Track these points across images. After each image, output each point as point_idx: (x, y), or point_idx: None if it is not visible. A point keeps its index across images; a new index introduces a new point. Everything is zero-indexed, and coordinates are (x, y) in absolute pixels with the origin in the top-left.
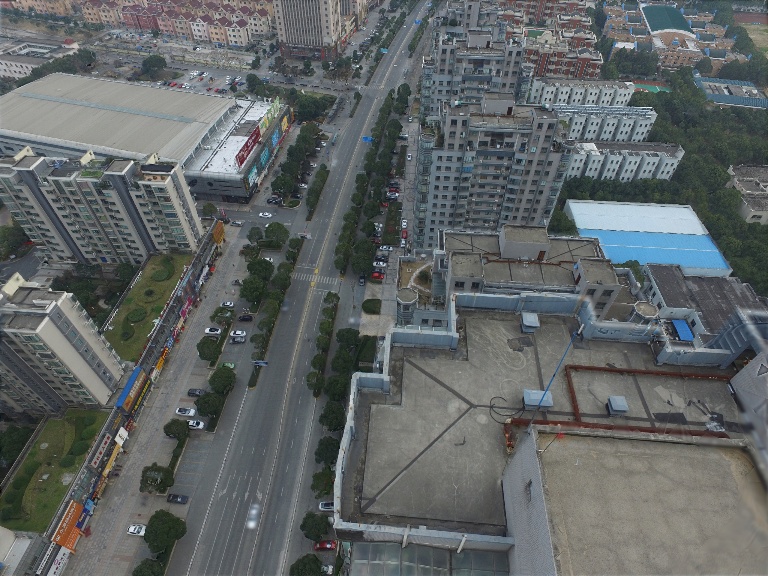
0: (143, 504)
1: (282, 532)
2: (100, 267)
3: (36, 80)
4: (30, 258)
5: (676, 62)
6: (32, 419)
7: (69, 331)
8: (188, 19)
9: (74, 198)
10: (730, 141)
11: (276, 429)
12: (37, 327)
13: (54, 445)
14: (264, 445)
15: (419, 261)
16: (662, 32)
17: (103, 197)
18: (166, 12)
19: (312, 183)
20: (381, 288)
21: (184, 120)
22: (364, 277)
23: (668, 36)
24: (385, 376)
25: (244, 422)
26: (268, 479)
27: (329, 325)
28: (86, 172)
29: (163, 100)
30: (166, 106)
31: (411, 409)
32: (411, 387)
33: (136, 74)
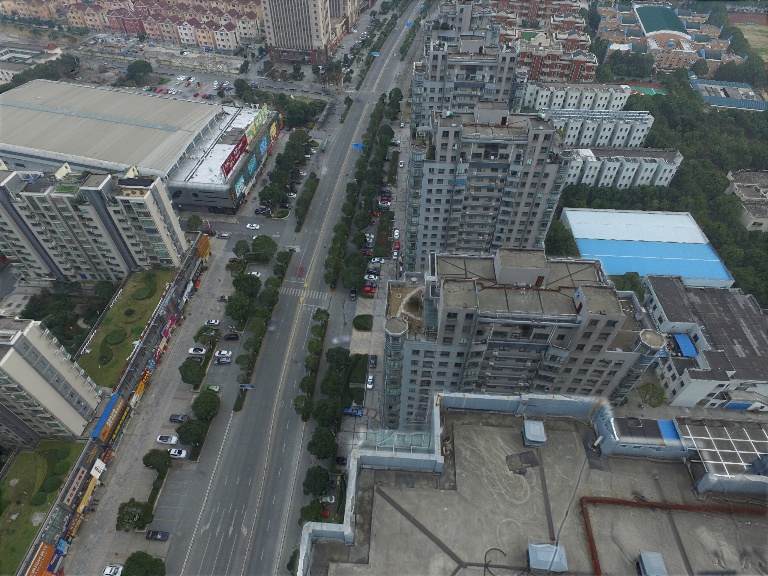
0: (121, 542)
1: (268, 570)
2: (79, 284)
3: (16, 87)
4: (6, 275)
5: (671, 64)
6: (4, 450)
7: (37, 361)
8: (175, 23)
9: (49, 214)
10: (728, 145)
11: (262, 457)
12: (0, 360)
13: (24, 481)
14: (250, 475)
15: (409, 285)
16: (657, 33)
17: (80, 213)
18: (152, 16)
19: (301, 192)
20: (373, 303)
21: (168, 128)
22: (355, 291)
23: (663, 37)
24: (346, 528)
25: (229, 450)
26: (254, 512)
27: (318, 344)
28: (61, 187)
29: (147, 107)
30: (150, 114)
31: (381, 570)
32: (382, 534)
33: (121, 80)
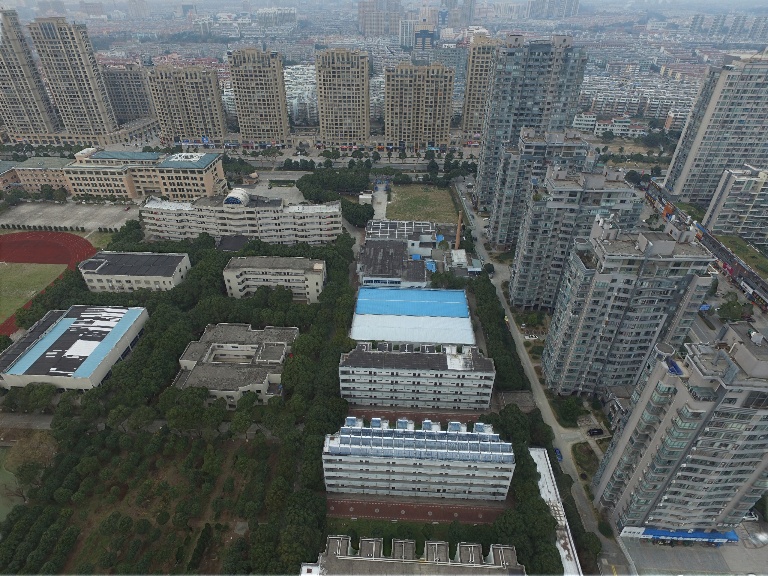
0: None
1: None
2: None
3: None
4: None
5: None
6: None
7: None
8: None
9: None
10: None
11: None
12: None
13: None
14: None
15: None
16: None
17: None
18: None
19: None
20: None
21: None
22: None
23: None
24: None
25: None
26: None
27: None
28: None
29: None
30: None
31: None
32: None
33: None
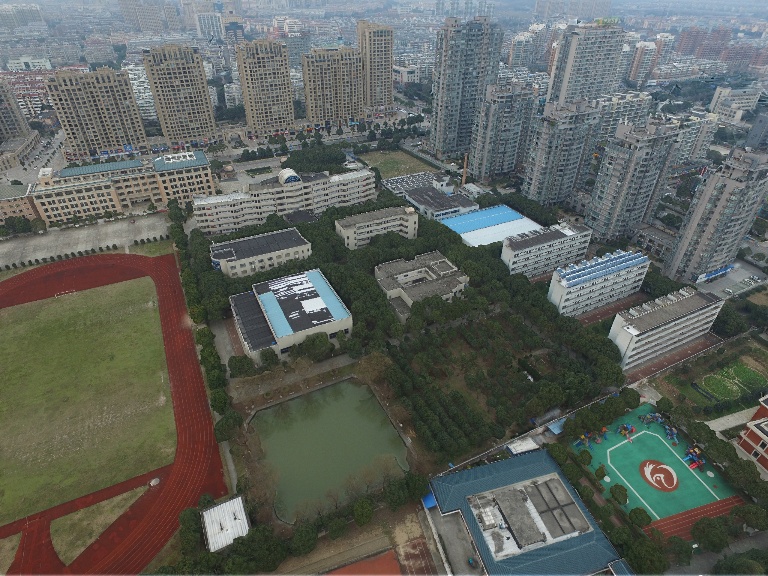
0: None
1: None
2: None
3: None
4: None
5: None
6: None
7: None
8: None
9: None
10: None
11: None
12: None
13: None
14: None
15: None
16: None
17: None
18: None
19: None
20: None
21: None
22: None
23: None
24: None
25: None
26: None
27: None
28: None
29: None
30: None
31: None
32: None
33: None
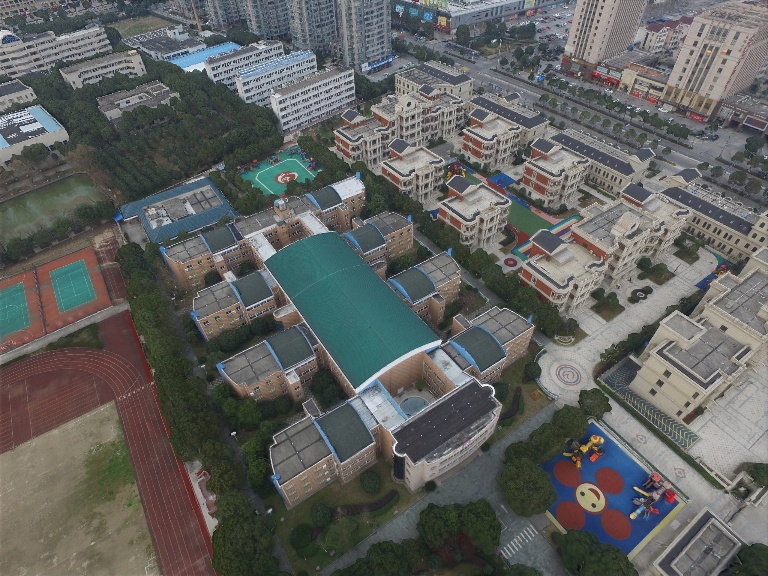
0: None
1: None
2: None
3: None
4: None
5: None
6: None
7: None
8: None
9: None
10: None
11: None
12: None
13: None
14: None
15: None
16: None
17: None
18: None
19: None
20: None
21: None
22: None
23: None
24: None
25: None
26: None
27: None
28: None
29: None
30: None
31: None
32: None
33: None
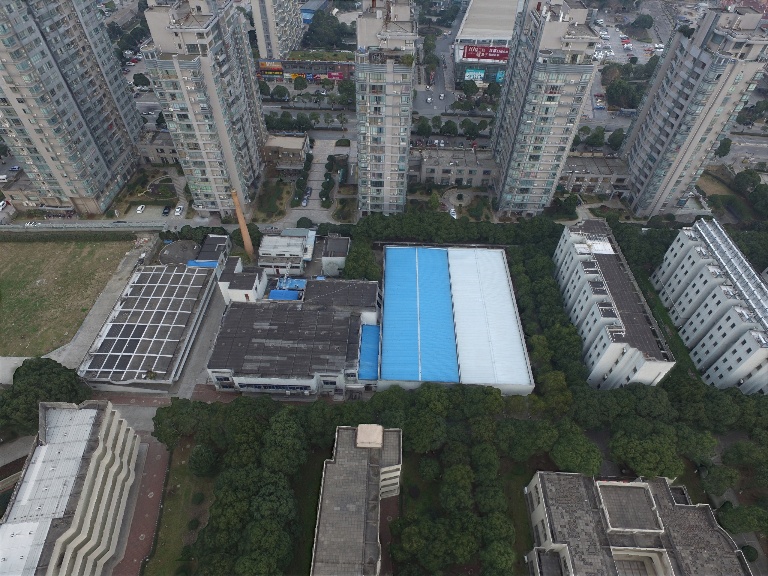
0: None
1: None
2: None
3: None
4: None
5: None
6: None
7: (262, 5)
8: None
9: None
10: None
11: None
12: None
13: None
14: None
15: None
16: None
17: None
18: (746, 1)
19: None
20: None
21: None
22: None
23: None
24: None
25: None
26: None
27: (313, 115)
28: None
29: None
30: None
31: None
32: None
33: (627, 25)
